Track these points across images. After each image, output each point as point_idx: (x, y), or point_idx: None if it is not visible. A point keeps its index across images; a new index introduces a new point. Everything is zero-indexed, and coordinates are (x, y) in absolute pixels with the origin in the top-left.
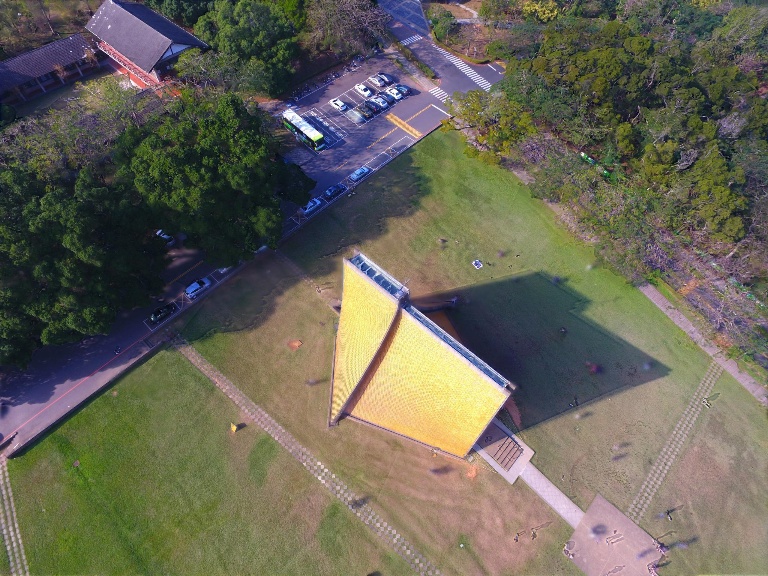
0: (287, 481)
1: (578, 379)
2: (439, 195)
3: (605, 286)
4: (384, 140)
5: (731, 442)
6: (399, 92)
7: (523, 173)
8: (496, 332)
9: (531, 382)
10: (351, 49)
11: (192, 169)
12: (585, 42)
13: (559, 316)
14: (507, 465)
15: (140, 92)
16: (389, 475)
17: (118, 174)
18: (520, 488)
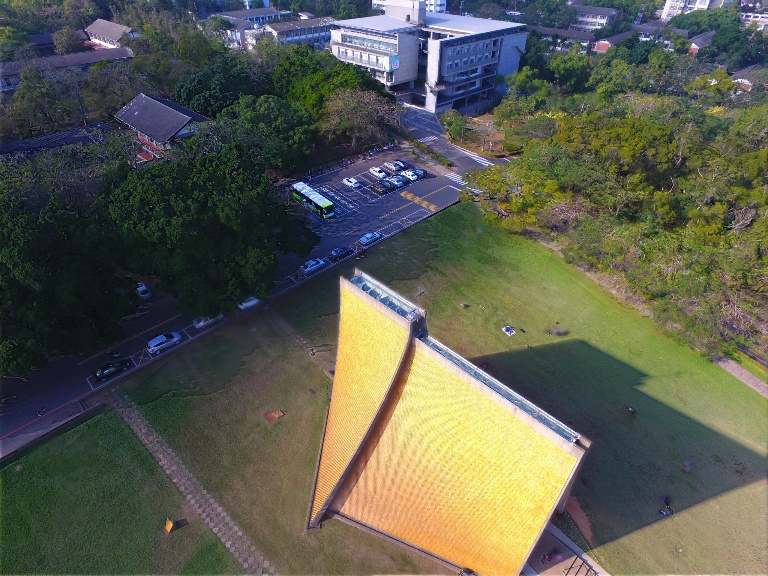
0: None
1: (665, 475)
2: (459, 261)
3: (674, 360)
4: (398, 212)
5: None
6: (415, 174)
7: (552, 244)
8: None
9: (598, 476)
10: (367, 132)
11: (178, 198)
12: None
13: (621, 392)
14: None
15: (150, 160)
16: None
17: (95, 203)
18: None
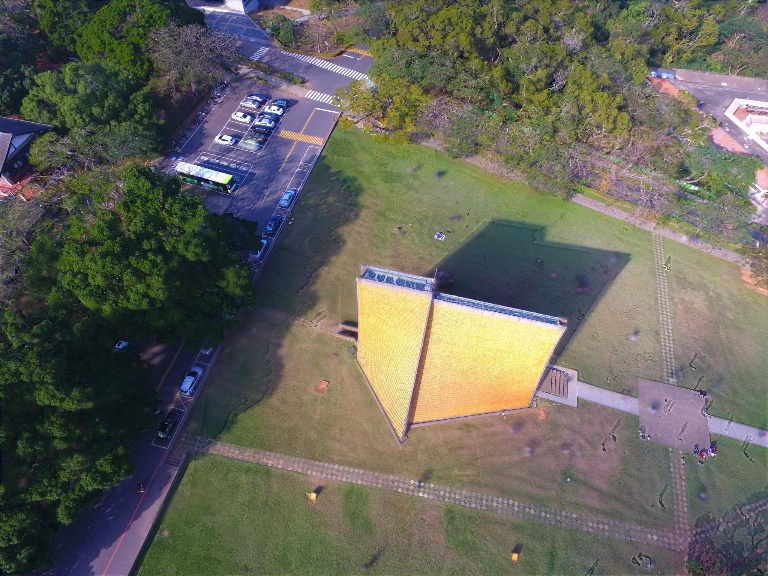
0: (393, 515)
1: (572, 295)
2: (371, 189)
3: (547, 210)
4: (291, 158)
5: (698, 289)
6: (279, 107)
7: (431, 141)
8: (490, 287)
9: None
10: (215, 80)
11: (138, 259)
12: (424, 7)
13: (529, 250)
14: (564, 393)
15: None
16: (478, 456)
17: (51, 300)
18: (583, 406)
